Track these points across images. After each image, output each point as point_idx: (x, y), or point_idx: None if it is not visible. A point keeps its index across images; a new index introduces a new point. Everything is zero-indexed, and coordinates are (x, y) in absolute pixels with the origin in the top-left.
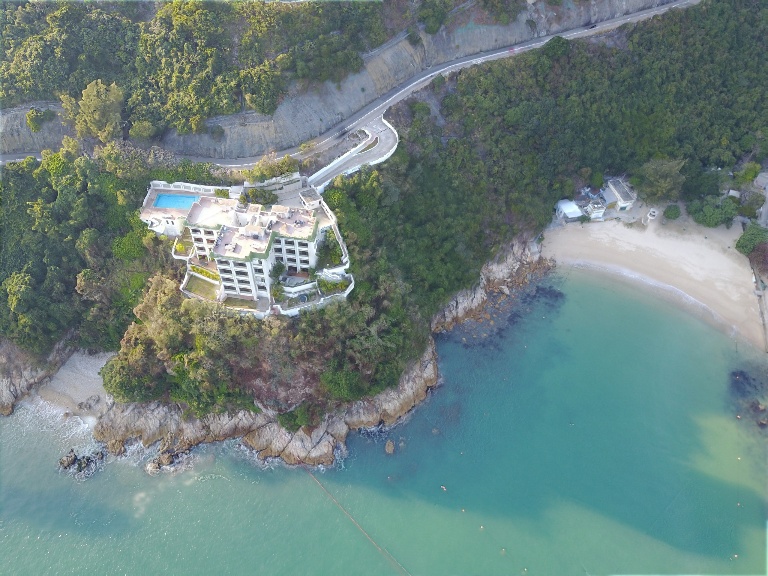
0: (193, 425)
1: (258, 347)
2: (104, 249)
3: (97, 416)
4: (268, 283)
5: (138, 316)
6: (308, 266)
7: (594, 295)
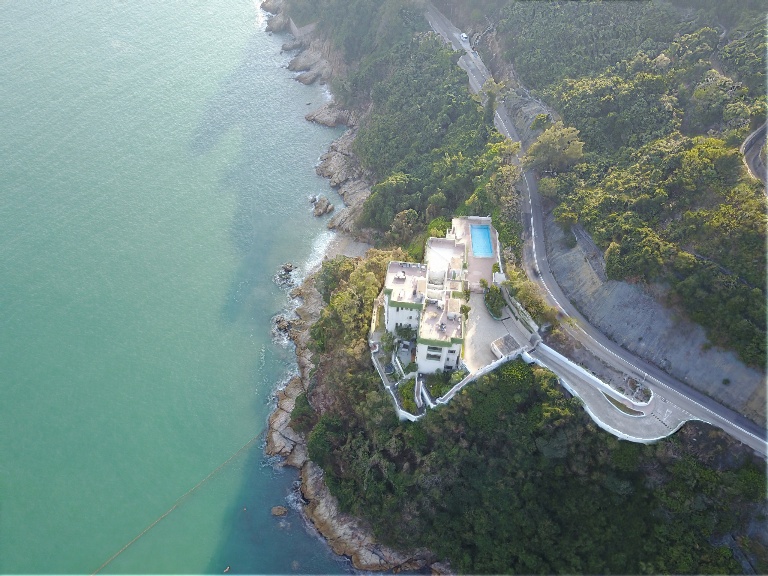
0: None
1: None
2: None
3: None
4: (391, 328)
5: None
6: (416, 361)
7: None
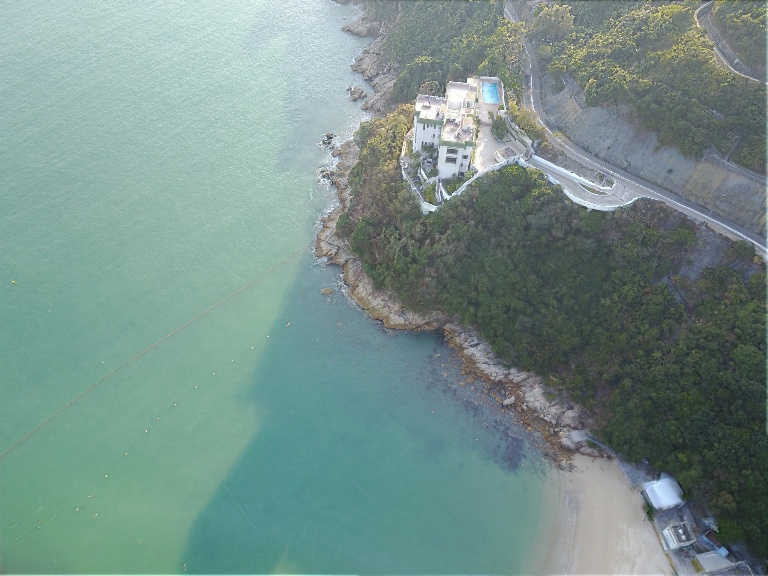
0: None
1: None
2: None
3: None
4: (418, 148)
5: None
6: (437, 167)
7: (523, 512)
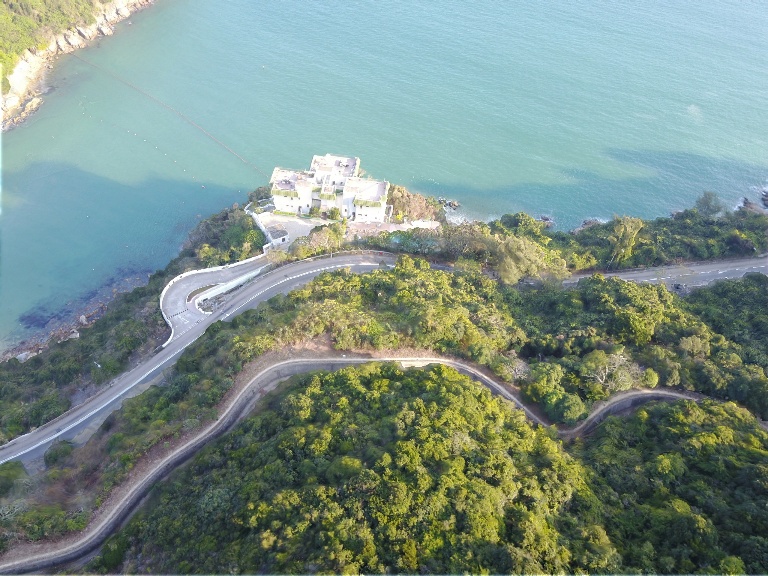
0: None
1: None
2: None
3: None
4: None
5: None
6: None
7: None
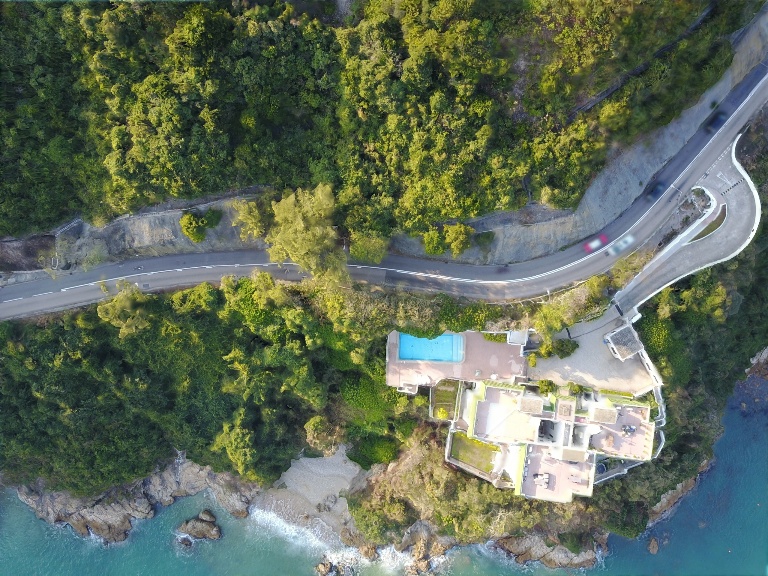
0: (448, 536)
1: None
2: (328, 384)
3: (341, 523)
4: None
5: None
6: None
7: None
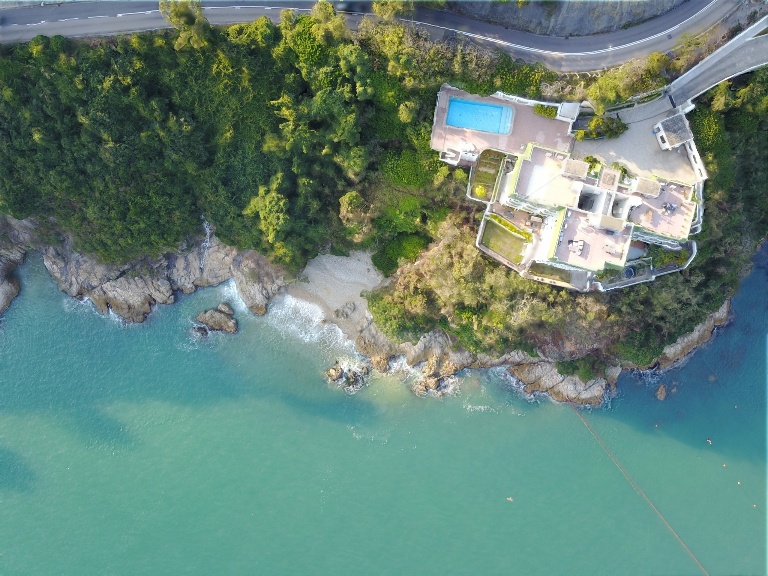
0: (461, 354)
1: (563, 323)
2: None
3: (357, 330)
4: None
5: (427, 277)
6: (651, 242)
7: None
